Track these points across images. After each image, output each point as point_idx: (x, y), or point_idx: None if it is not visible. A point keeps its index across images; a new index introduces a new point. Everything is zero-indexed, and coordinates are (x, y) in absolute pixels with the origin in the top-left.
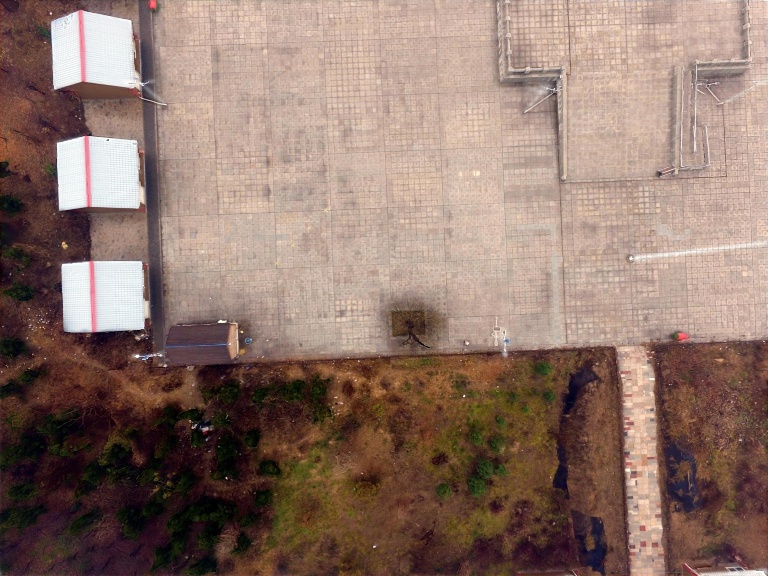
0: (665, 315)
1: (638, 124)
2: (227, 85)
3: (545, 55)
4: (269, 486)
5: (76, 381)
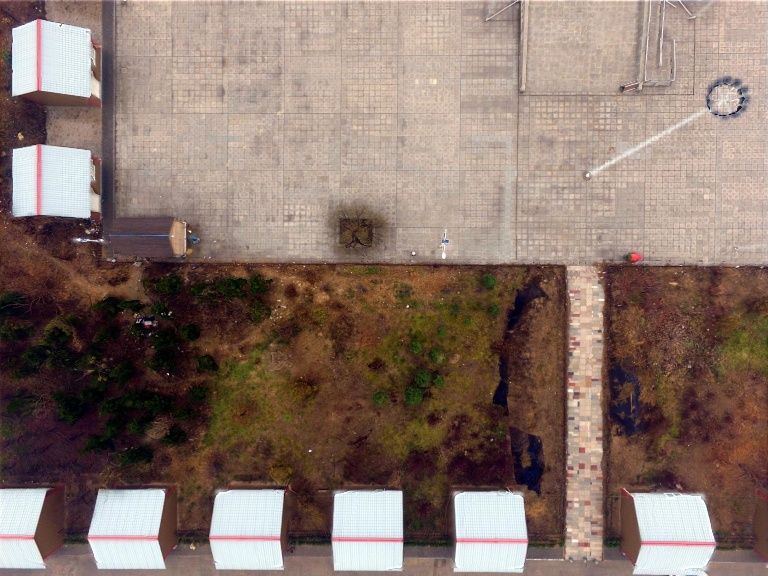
0: (620, 236)
1: (603, 35)
2: None
3: None
4: (209, 384)
5: (26, 269)
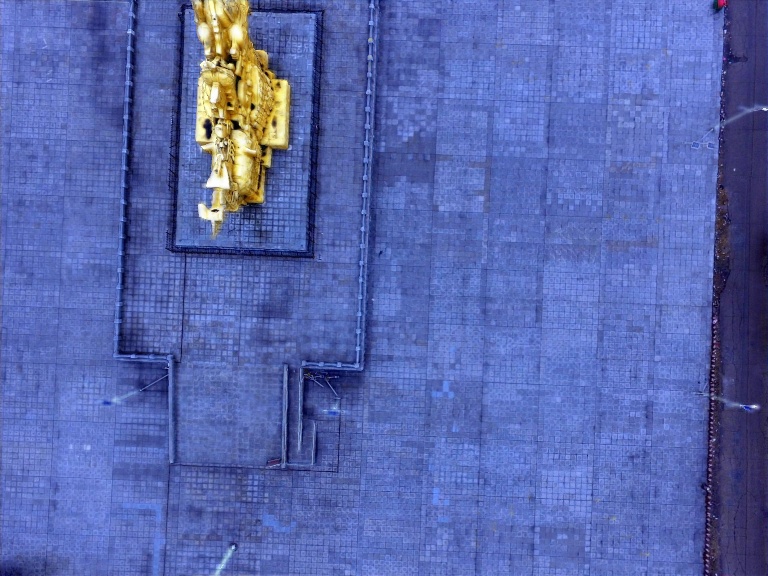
0: None
1: (249, 414)
2: None
3: (157, 341)
4: None
5: None
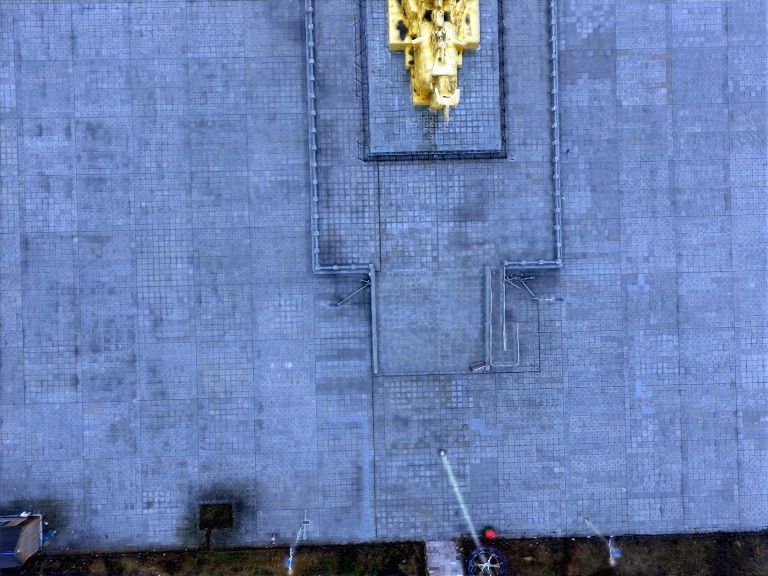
0: (476, 510)
1: (450, 320)
2: (36, 273)
3: (355, 251)
4: None
5: None
